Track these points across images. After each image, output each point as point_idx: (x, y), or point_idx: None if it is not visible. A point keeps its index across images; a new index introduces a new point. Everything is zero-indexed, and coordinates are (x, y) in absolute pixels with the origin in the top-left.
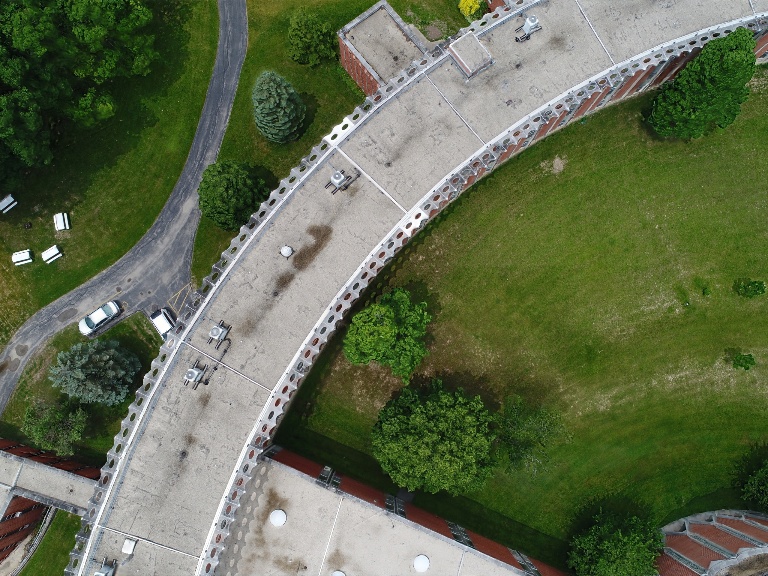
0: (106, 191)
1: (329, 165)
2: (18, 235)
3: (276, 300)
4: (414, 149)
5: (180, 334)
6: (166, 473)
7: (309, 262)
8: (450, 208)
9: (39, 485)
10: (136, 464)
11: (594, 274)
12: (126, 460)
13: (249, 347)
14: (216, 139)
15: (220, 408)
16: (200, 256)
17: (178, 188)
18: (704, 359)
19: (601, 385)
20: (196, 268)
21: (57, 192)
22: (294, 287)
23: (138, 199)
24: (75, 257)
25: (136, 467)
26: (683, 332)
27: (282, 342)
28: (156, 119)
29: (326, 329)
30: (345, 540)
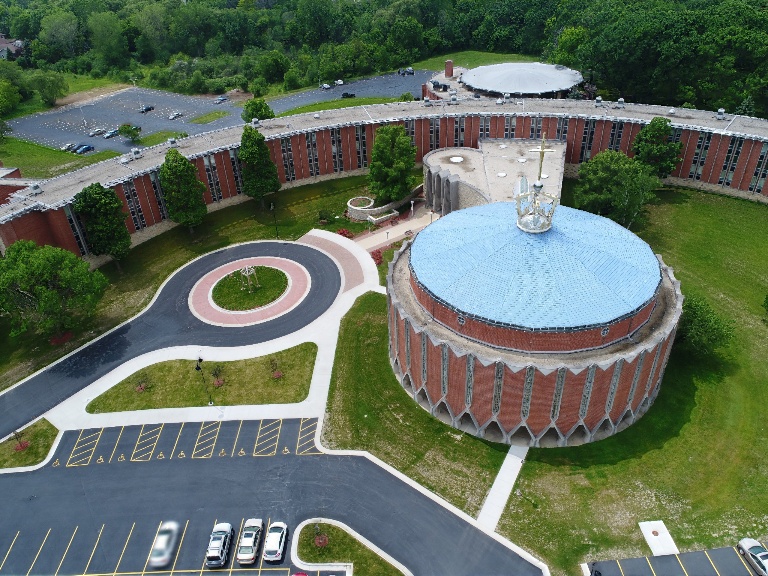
0: None
1: None
2: None
3: None
4: (761, 129)
5: None
6: None
7: None
8: (745, 200)
9: None
10: None
11: (763, 252)
12: None
13: None
14: None
15: None
16: None
17: None
18: (753, 309)
19: (687, 266)
20: None
21: None
22: None
23: None
24: None
25: None
26: (764, 297)
27: None
28: None
29: (645, 122)
30: None
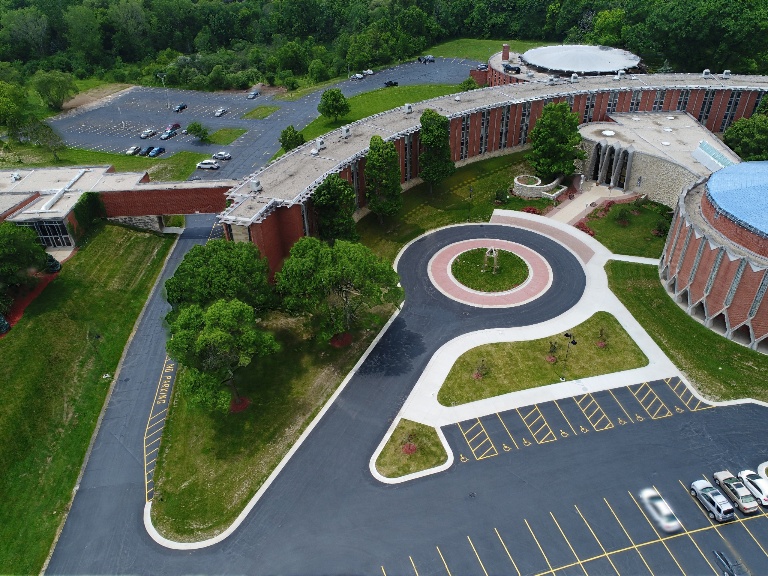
0: None
1: None
2: None
3: None
4: None
5: None
6: None
7: None
8: None
9: None
10: None
11: None
12: None
13: None
14: None
15: None
16: None
17: None
18: None
19: None
20: None
21: None
22: None
23: None
24: None
25: None
26: None
27: None
28: None
29: None
30: (684, 129)
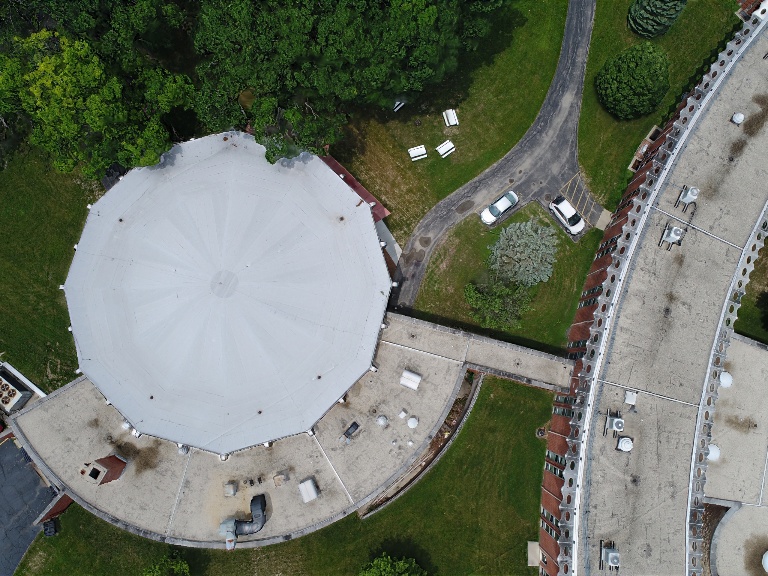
0: (487, 88)
1: (764, 37)
2: (408, 133)
3: (732, 165)
4: None
5: (646, 200)
6: (654, 329)
7: (758, 128)
8: None
9: (487, 359)
10: (624, 322)
11: None
12: (614, 318)
13: (714, 209)
14: (585, 36)
15: (696, 267)
16: (585, 147)
17: (555, 83)
18: None
19: None
20: (583, 158)
21: (441, 91)
22: (748, 152)
23: (518, 95)
24: (466, 152)
25: (624, 324)
26: None
27: (745, 203)
28: (524, 19)
29: None
30: None
